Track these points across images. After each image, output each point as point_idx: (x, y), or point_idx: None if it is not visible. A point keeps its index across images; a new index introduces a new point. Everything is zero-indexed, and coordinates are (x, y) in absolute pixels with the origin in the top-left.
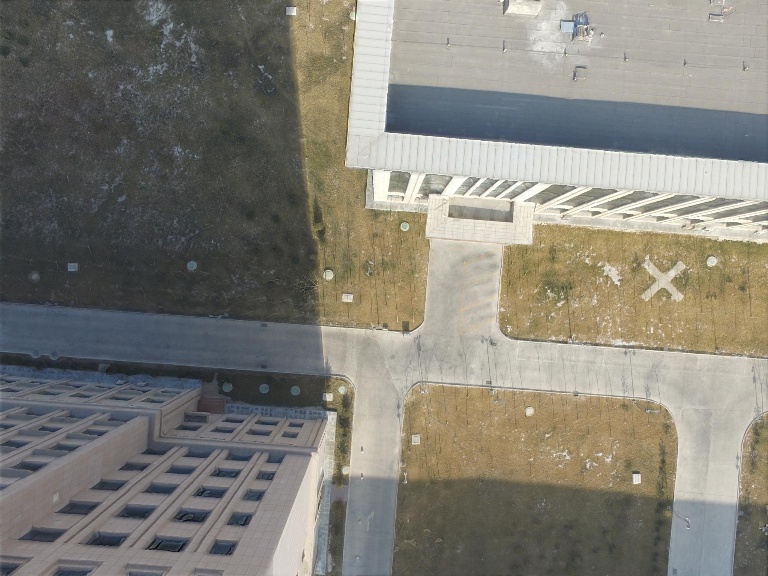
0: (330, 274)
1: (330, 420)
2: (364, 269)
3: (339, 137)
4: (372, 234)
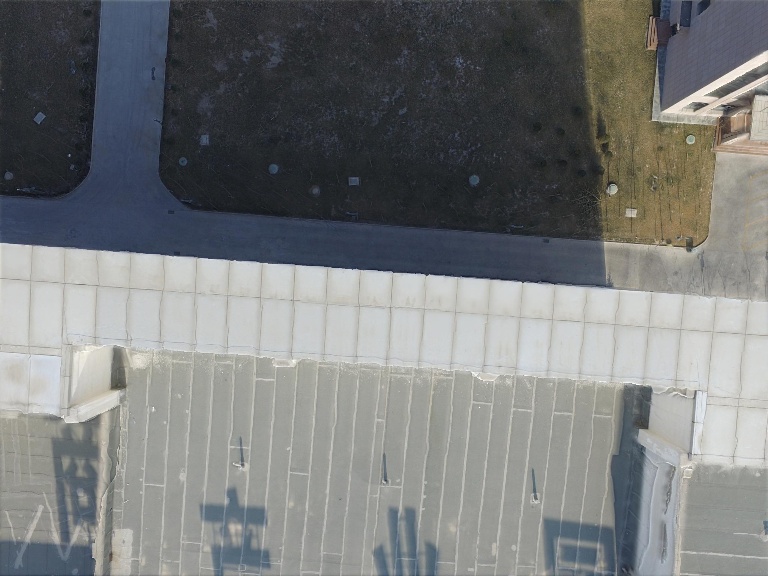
0: (615, 188)
1: None
2: (648, 183)
3: (624, 47)
4: (657, 147)
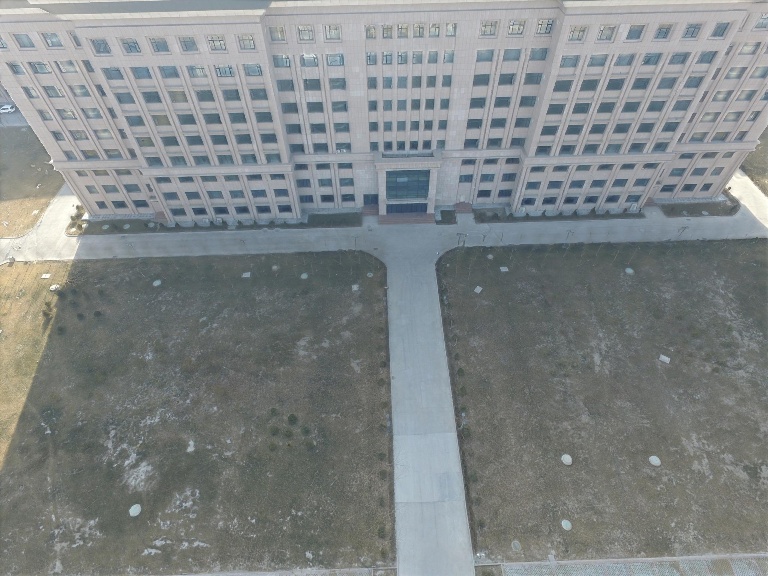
0: (52, 287)
1: (87, 216)
2: (25, 293)
3: (1, 381)
4: (7, 315)
